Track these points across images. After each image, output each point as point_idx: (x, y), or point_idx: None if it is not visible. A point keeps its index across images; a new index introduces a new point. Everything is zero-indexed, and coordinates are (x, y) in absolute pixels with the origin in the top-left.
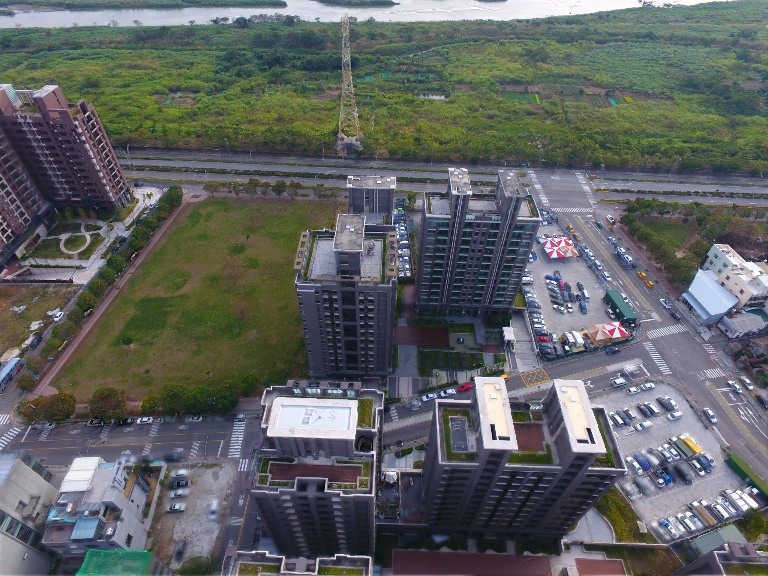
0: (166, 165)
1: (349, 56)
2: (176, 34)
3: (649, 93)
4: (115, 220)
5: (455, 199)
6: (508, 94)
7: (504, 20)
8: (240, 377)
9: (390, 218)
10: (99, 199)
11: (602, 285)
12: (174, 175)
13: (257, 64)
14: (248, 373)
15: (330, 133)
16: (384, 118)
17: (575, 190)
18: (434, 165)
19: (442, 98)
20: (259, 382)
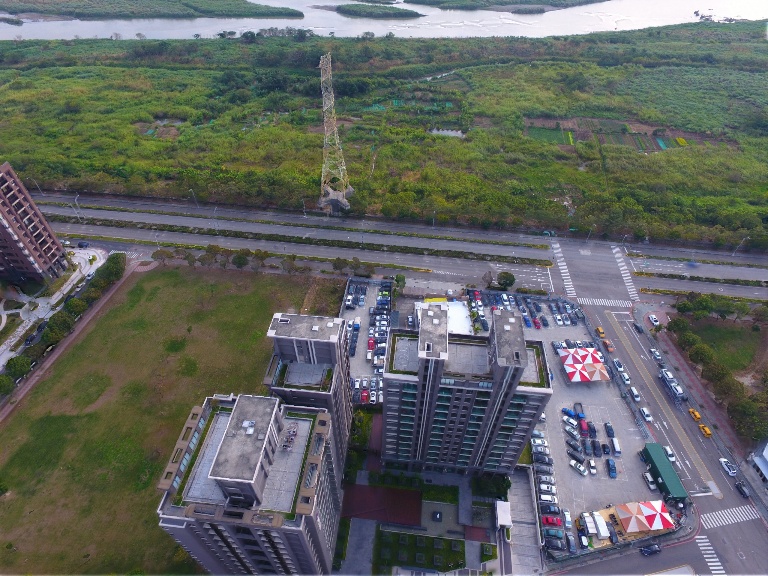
0: (122, 218)
1: (331, 102)
2: (176, 50)
3: (707, 133)
4: (42, 295)
5: (423, 362)
6: (536, 131)
7: (539, 37)
8: (131, 561)
9: (330, 379)
10: (24, 270)
11: (639, 428)
12: (127, 232)
13: (256, 87)
14: (143, 554)
15: (319, 180)
16: (387, 160)
17: (609, 272)
18: (436, 229)
19: (458, 133)
20: (153, 574)
